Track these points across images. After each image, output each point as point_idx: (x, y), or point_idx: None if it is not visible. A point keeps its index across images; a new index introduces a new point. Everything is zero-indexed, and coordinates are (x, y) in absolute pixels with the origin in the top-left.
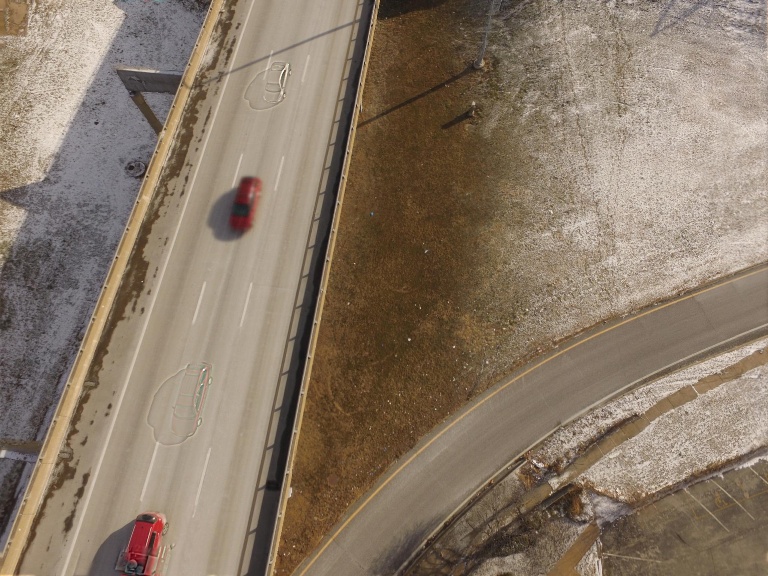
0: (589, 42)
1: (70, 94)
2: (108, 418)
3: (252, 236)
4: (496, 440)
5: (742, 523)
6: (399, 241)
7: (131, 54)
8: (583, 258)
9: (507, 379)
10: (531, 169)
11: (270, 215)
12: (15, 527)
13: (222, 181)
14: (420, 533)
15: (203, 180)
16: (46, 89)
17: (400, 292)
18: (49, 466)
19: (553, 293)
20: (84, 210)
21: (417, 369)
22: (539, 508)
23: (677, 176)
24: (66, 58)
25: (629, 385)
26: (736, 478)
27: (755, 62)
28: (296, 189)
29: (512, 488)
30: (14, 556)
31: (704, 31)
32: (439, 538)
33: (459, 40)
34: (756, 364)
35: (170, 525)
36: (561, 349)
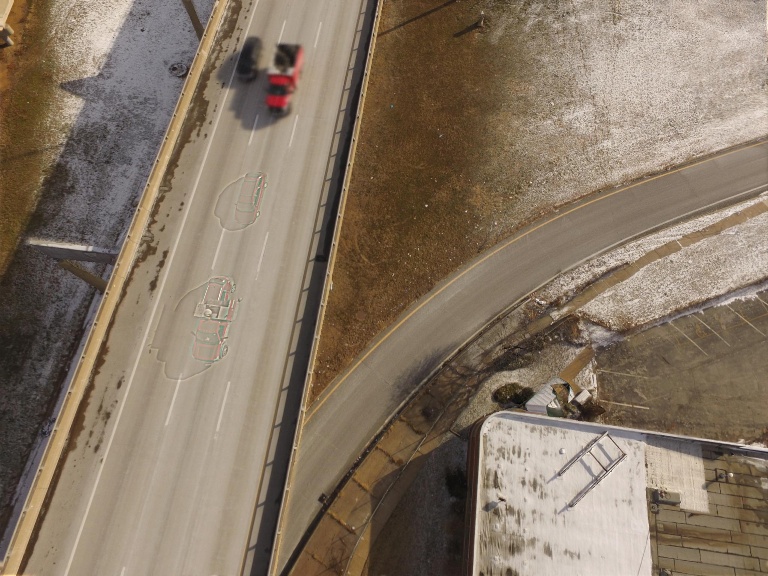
0: None
1: (119, 4)
2: (181, 212)
3: (296, 81)
4: (504, 284)
5: (719, 349)
6: (416, 128)
7: None
8: (581, 141)
9: (513, 236)
10: (534, 69)
11: (311, 65)
12: (111, 282)
13: (269, 41)
14: (438, 357)
15: (252, 40)
16: None
17: (418, 168)
18: (135, 245)
19: (554, 169)
20: (134, 101)
21: (434, 229)
22: (542, 334)
23: (666, 75)
24: None
25: (621, 241)
26: (715, 314)
27: None
28: (333, 46)
29: (518, 319)
30: (110, 306)
31: None
32: (454, 359)
33: None
34: (734, 223)
35: (237, 285)
36: (561, 213)
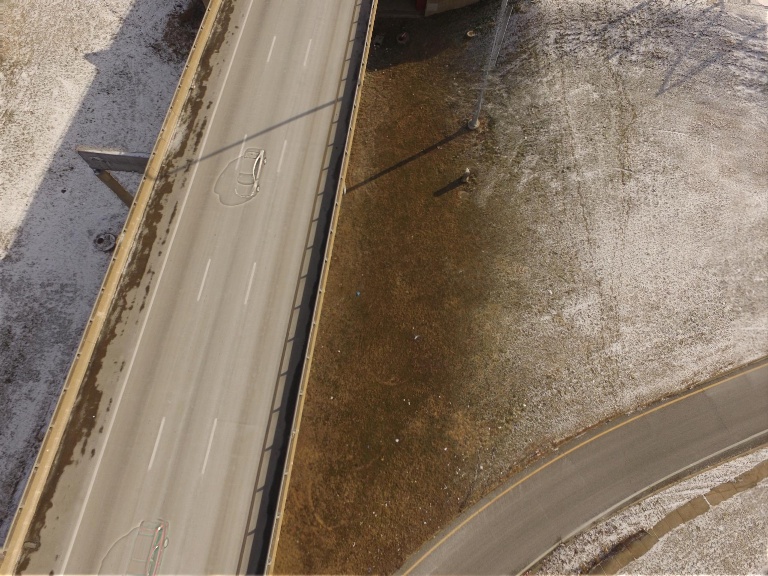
0: (591, 102)
1: (35, 160)
2: None
3: (218, 360)
4: (491, 559)
5: None
6: (387, 325)
7: (103, 113)
8: (585, 345)
9: (503, 487)
10: (529, 243)
11: (239, 335)
12: None
13: (187, 292)
14: None
15: (166, 291)
16: (9, 155)
17: (388, 385)
18: None
19: (553, 386)
20: (48, 290)
21: (405, 475)
22: None
23: (685, 251)
24: (32, 120)
25: (635, 494)
26: None
27: (767, 124)
28: (268, 302)
29: None
30: None
31: (713, 90)
32: None
33: (452, 97)
34: None
35: None
36: (561, 452)
